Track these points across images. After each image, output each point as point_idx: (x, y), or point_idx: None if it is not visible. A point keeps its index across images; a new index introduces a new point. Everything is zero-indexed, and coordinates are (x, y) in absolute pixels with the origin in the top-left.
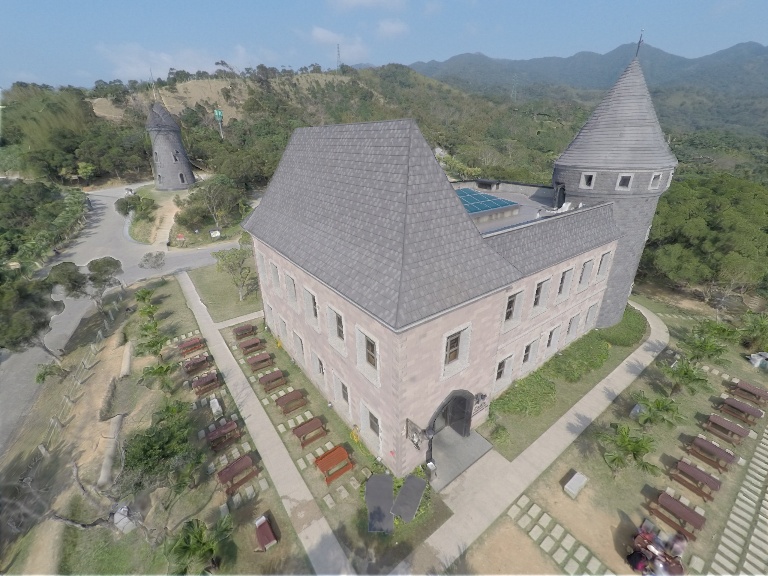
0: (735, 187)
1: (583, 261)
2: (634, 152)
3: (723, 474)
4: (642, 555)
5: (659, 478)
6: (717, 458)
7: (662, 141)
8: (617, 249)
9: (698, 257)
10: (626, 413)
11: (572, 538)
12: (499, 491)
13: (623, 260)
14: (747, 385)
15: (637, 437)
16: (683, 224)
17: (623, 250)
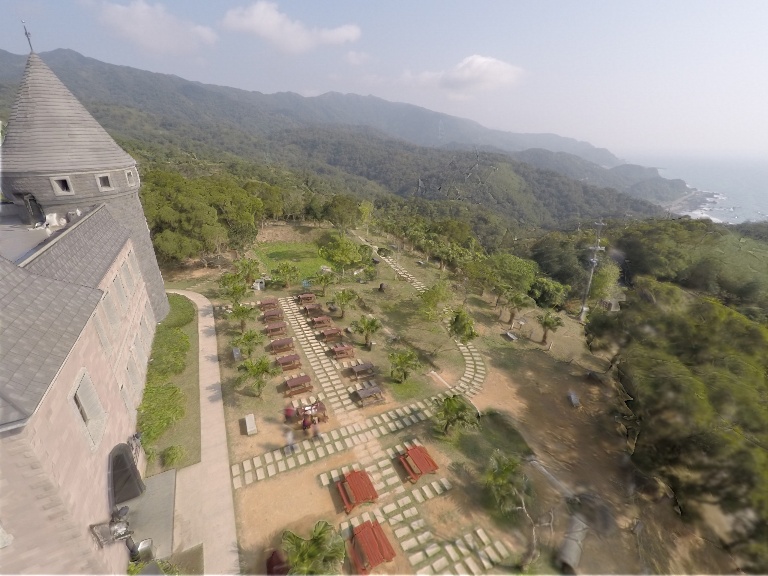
0: (168, 179)
1: (120, 265)
2: (96, 153)
3: (294, 350)
4: (308, 415)
5: (277, 377)
6: (287, 344)
7: (112, 142)
8: (133, 246)
9: (184, 236)
10: (232, 361)
11: (277, 451)
12: (215, 486)
13: (144, 254)
14: (266, 301)
15: (258, 361)
16: (158, 214)
17: (139, 246)
